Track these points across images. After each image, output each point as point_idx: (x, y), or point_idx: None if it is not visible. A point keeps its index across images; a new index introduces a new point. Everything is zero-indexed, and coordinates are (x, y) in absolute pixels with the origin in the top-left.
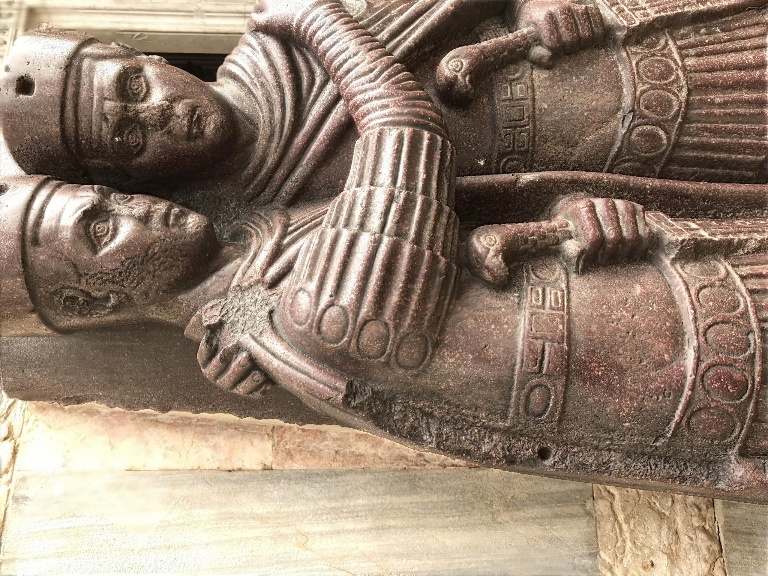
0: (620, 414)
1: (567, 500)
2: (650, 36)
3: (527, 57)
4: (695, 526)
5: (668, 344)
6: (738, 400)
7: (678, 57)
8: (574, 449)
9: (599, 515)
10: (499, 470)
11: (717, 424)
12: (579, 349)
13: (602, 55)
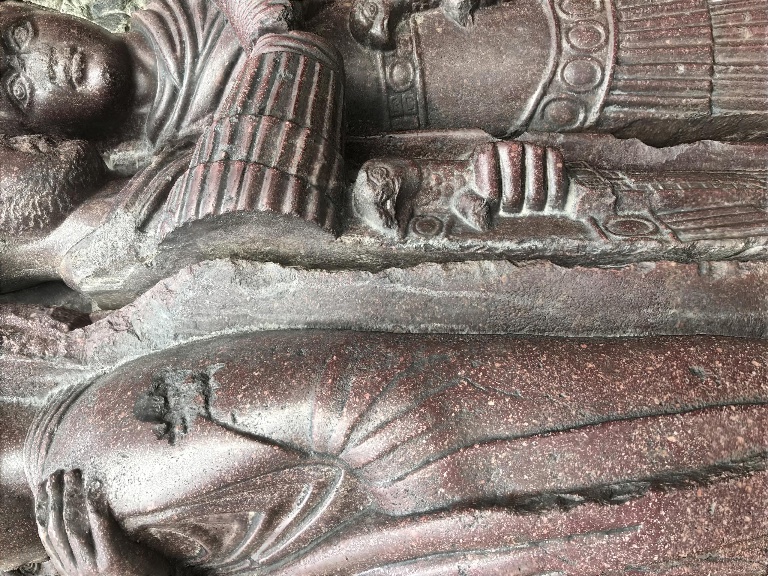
0: None
1: None
2: None
3: None
4: None
5: None
6: None
7: None
8: None
9: None
10: None
11: None
12: None
13: None
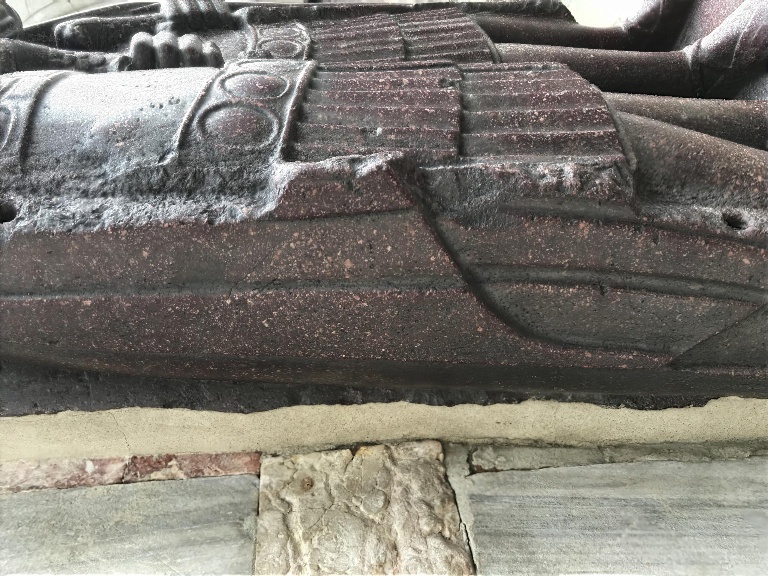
0: (109, 131)
1: (211, 519)
2: (279, 22)
3: (155, 33)
4: (425, 532)
5: (191, 74)
6: (272, 97)
7: (303, 27)
8: (51, 201)
9: (261, 533)
10: (107, 487)
11: (244, 122)
12: (70, 85)
13: (231, 32)
